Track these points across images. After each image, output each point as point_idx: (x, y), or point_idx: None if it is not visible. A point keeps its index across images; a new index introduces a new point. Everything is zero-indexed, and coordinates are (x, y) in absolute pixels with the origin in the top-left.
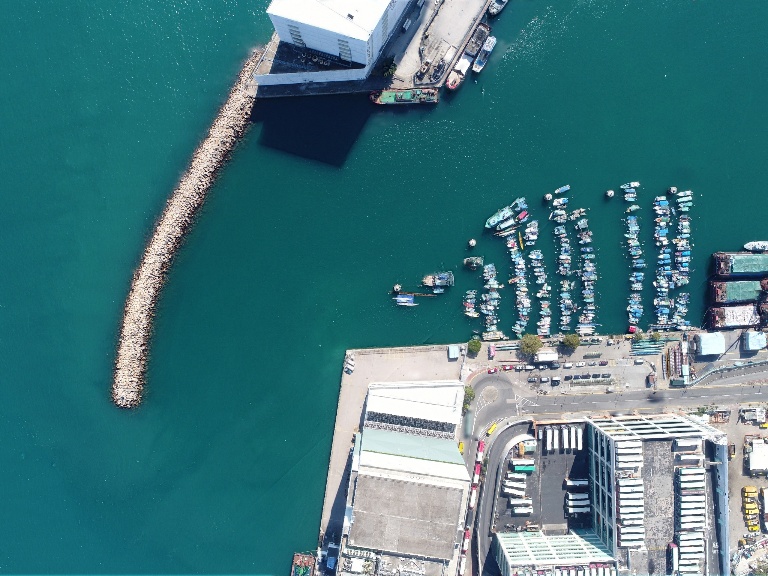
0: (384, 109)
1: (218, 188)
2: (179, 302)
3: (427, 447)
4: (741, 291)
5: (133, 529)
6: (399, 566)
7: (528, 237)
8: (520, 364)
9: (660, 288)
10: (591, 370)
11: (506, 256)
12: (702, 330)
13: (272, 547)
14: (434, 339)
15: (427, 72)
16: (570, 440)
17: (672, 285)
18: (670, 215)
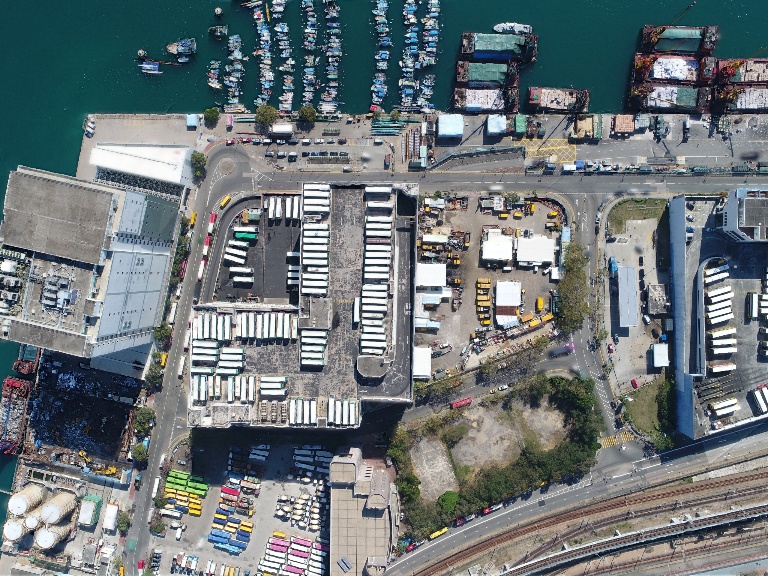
0: None
1: None
2: None
3: None
4: (484, 71)
5: None
6: (49, 270)
7: (274, 9)
8: (258, 137)
9: (405, 68)
10: (329, 148)
11: (253, 29)
12: (446, 113)
13: None
14: (176, 108)
15: None
16: (293, 209)
17: (417, 65)
18: None
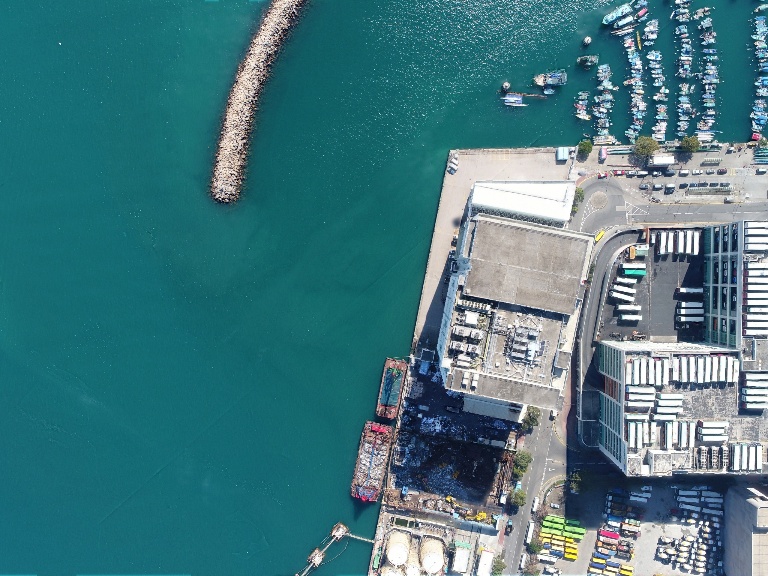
0: None
1: None
2: (281, 98)
3: None
4: None
5: (225, 326)
6: (515, 321)
7: (647, 36)
8: (632, 170)
9: None
10: (708, 179)
11: (622, 57)
12: None
13: (364, 351)
14: (542, 142)
15: None
16: (685, 244)
17: None
18: None
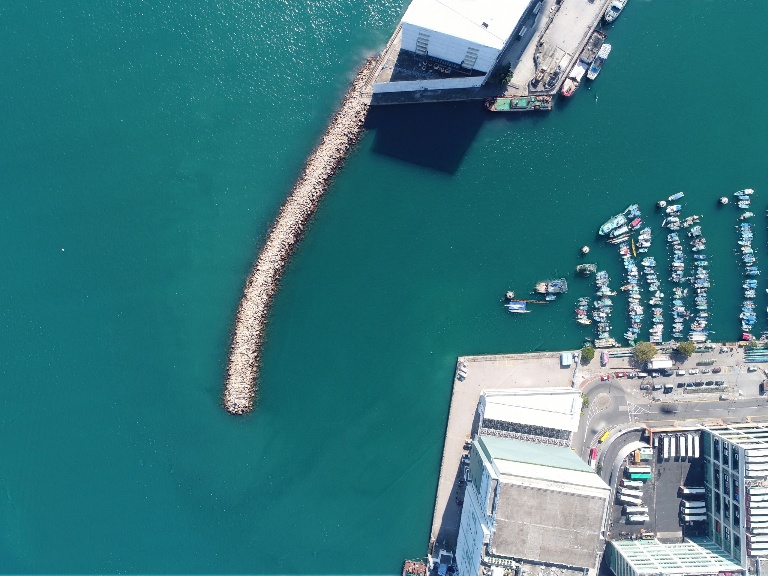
0: (498, 116)
1: (330, 195)
2: (290, 309)
3: (550, 455)
4: None
5: (243, 535)
6: (540, 575)
7: (641, 244)
8: (633, 371)
9: None
10: (704, 377)
11: (618, 263)
12: None
13: (382, 554)
14: (546, 346)
15: (541, 79)
16: (687, 448)
17: None
18: None
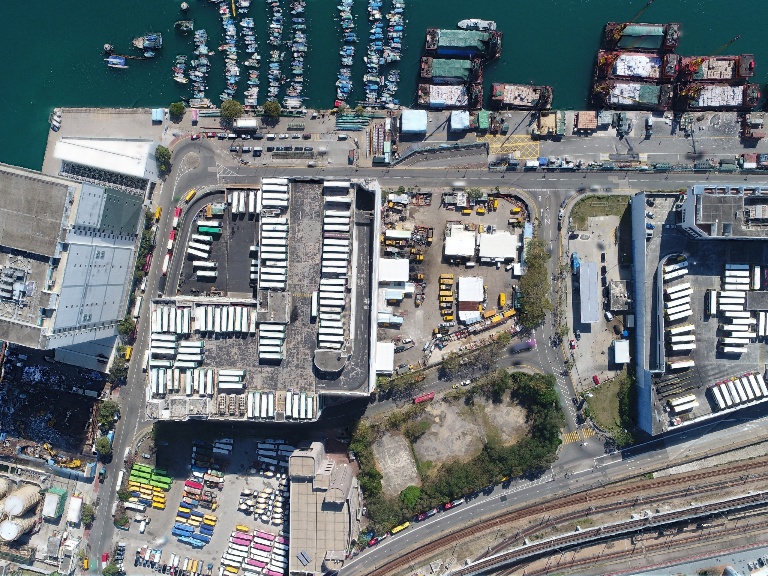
0: None
1: None
2: None
3: None
4: (447, 67)
5: None
6: (5, 262)
7: (240, 4)
8: (223, 132)
9: (370, 64)
10: (294, 143)
11: (219, 24)
12: (410, 109)
13: None
14: (142, 103)
15: None
16: (256, 204)
17: (382, 61)
18: None
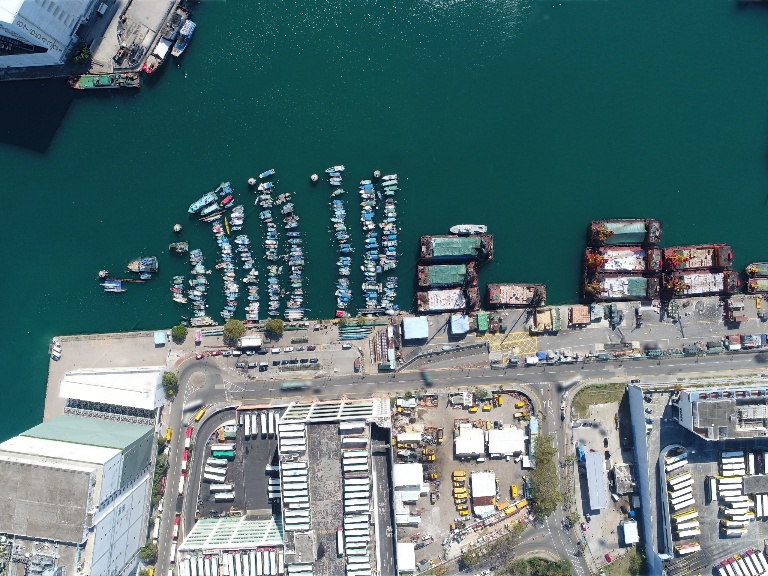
0: (86, 94)
1: None
2: None
3: (106, 432)
4: (444, 275)
5: None
6: (32, 550)
7: (233, 222)
8: (228, 349)
9: (367, 272)
10: (299, 355)
11: (214, 241)
12: (410, 314)
13: None
14: (142, 325)
15: (126, 56)
16: (268, 425)
17: (379, 269)
18: (376, 199)
